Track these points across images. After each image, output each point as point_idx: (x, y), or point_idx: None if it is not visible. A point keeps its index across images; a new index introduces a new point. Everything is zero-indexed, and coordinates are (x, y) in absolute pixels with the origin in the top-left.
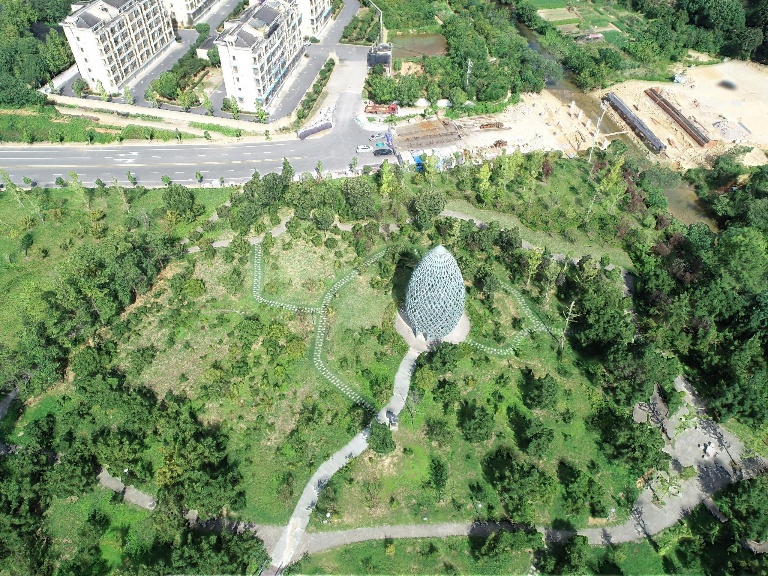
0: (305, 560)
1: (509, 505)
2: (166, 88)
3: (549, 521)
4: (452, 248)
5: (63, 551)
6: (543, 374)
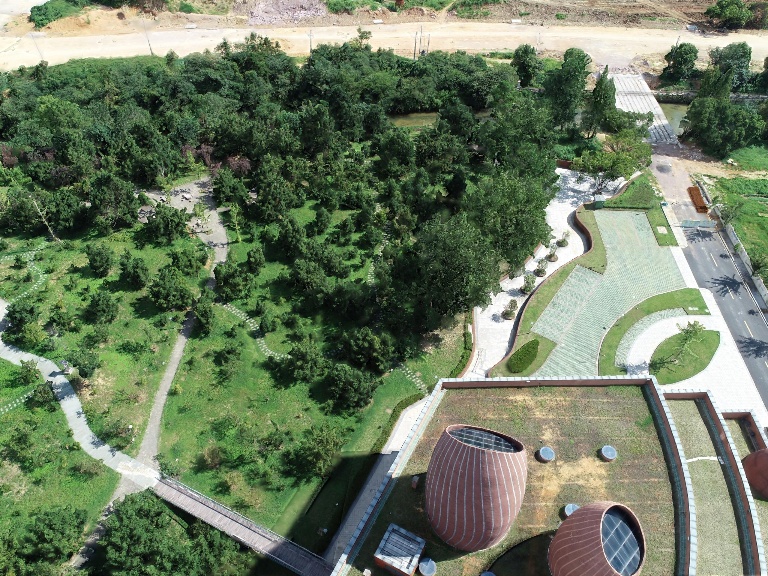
0: (161, 455)
1: (178, 302)
2: None
3: (197, 289)
4: None
5: None
6: (80, 262)
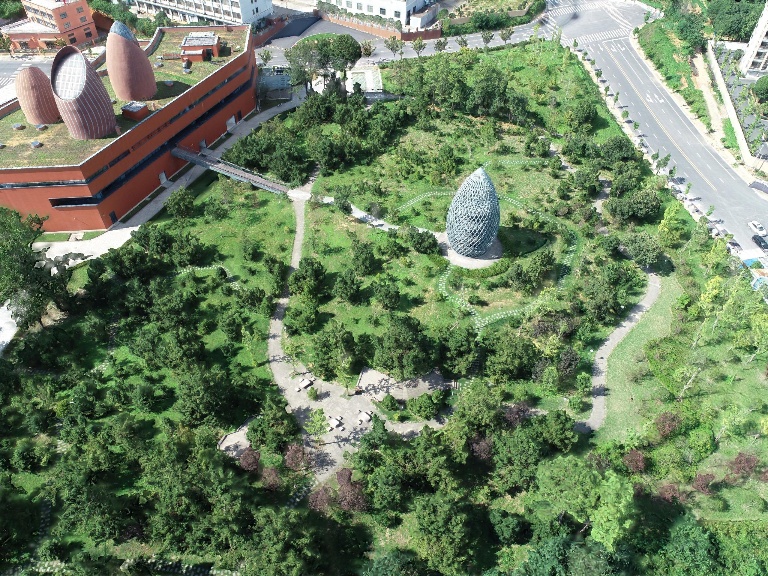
0: None
1: None
2: (756, 86)
3: (291, 305)
4: (582, 270)
5: None
6: (420, 314)
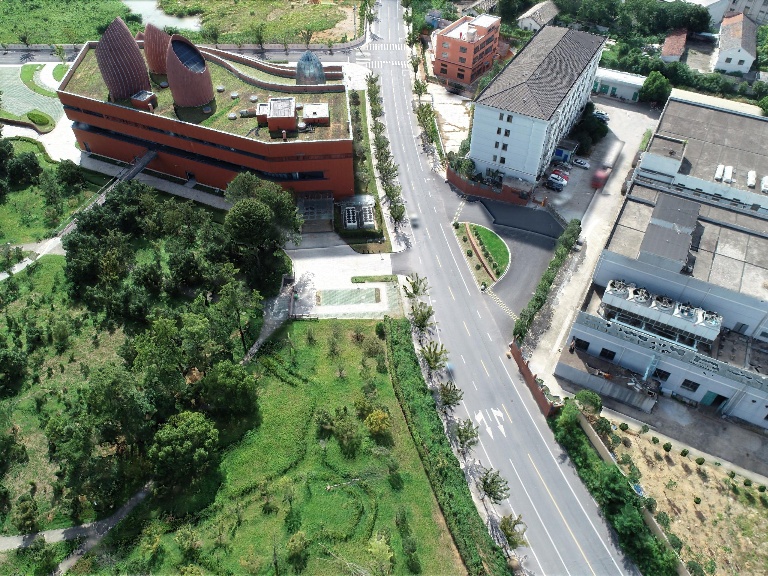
0: None
1: None
2: None
3: None
4: None
5: (198, 254)
6: None
